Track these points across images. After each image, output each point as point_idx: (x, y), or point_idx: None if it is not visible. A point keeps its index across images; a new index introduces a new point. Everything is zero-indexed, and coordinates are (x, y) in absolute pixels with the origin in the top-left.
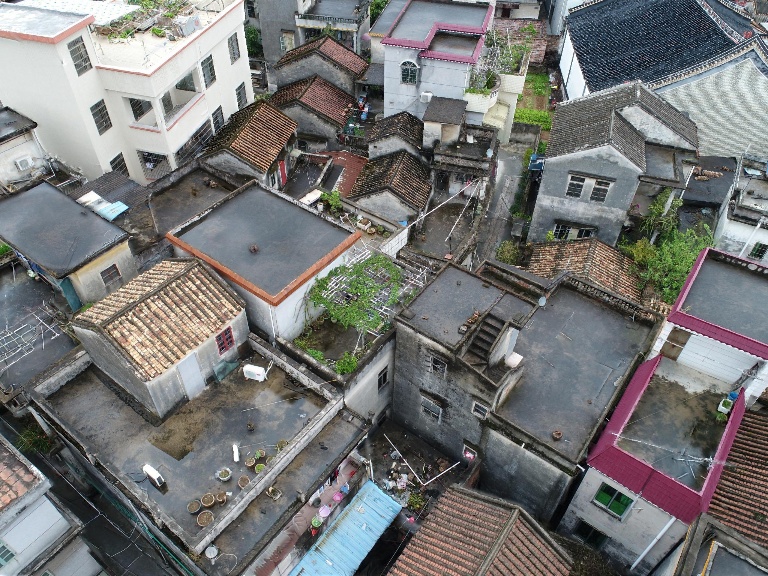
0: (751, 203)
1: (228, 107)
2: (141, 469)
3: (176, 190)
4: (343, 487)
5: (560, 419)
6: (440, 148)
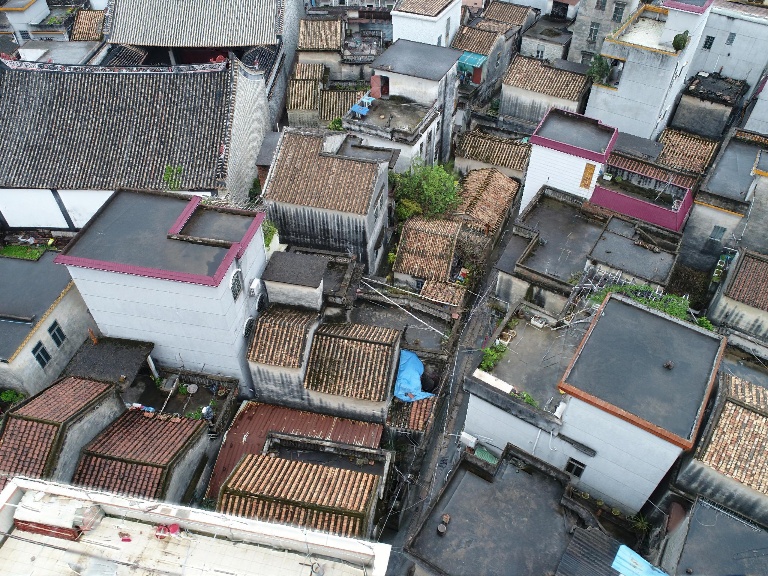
0: None
1: None
2: None
3: (464, 573)
4: None
5: None
6: None
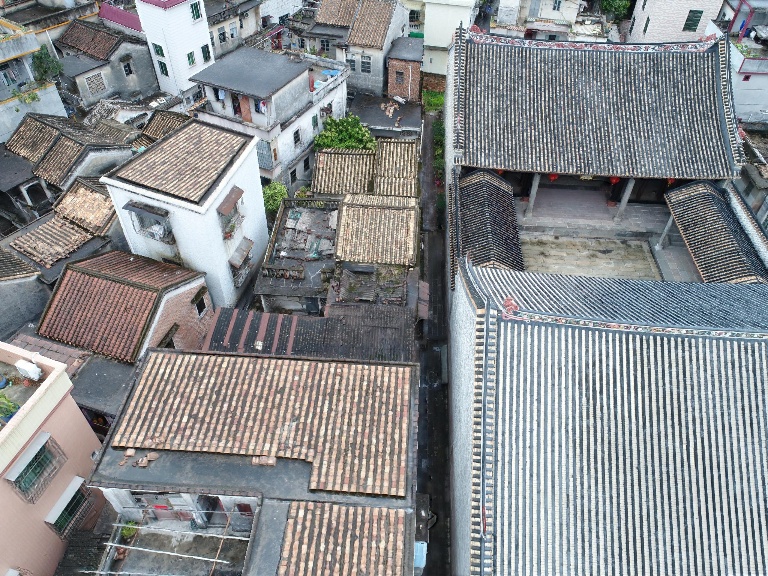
0: None
1: None
2: None
3: None
4: None
5: None
6: None
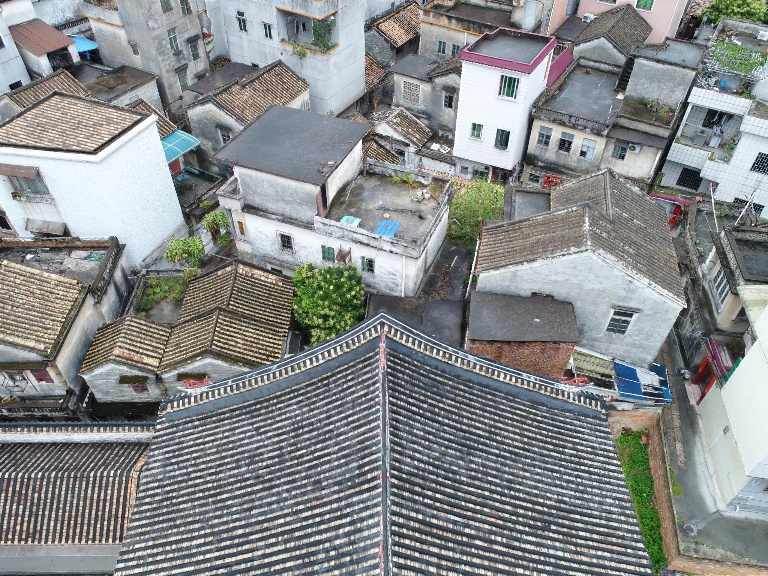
0: (426, 205)
1: None
2: None
3: None
4: None
5: (587, 78)
6: None
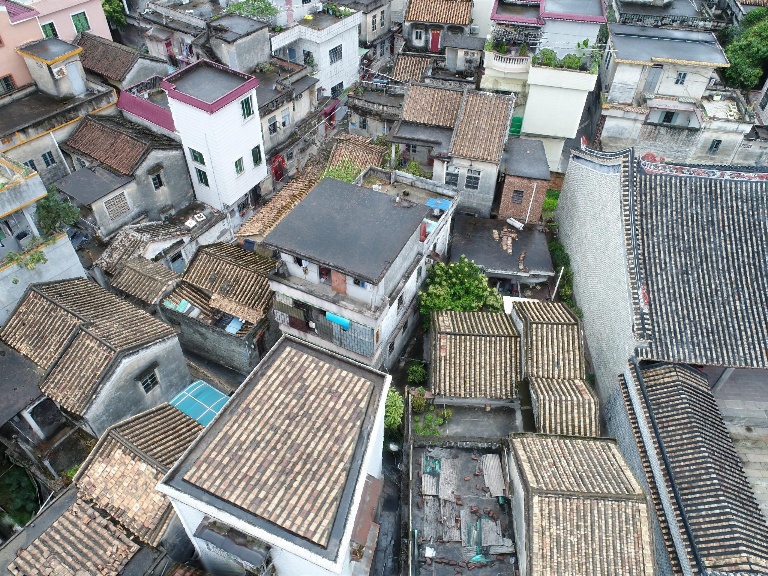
0: (390, 190)
1: (480, 3)
2: (191, 1)
3: None
4: (191, 61)
5: None
6: (453, 69)
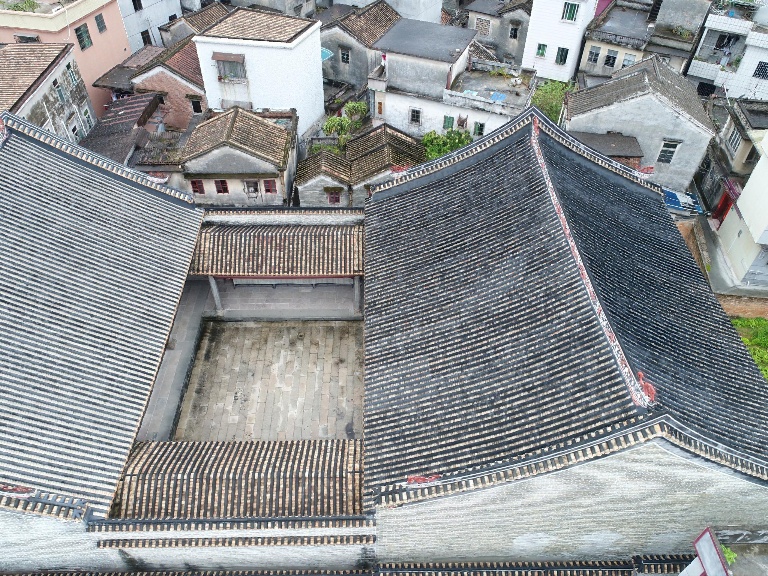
0: (519, 88)
1: None
2: None
3: None
4: None
5: None
6: None
